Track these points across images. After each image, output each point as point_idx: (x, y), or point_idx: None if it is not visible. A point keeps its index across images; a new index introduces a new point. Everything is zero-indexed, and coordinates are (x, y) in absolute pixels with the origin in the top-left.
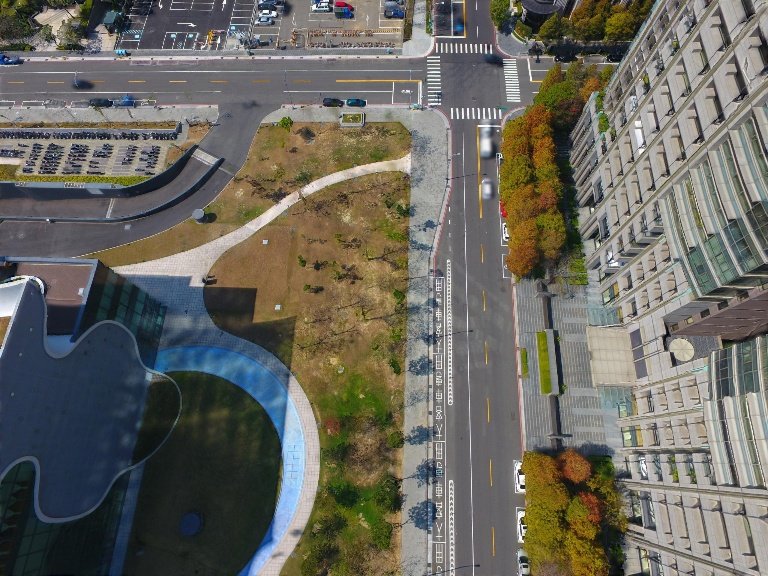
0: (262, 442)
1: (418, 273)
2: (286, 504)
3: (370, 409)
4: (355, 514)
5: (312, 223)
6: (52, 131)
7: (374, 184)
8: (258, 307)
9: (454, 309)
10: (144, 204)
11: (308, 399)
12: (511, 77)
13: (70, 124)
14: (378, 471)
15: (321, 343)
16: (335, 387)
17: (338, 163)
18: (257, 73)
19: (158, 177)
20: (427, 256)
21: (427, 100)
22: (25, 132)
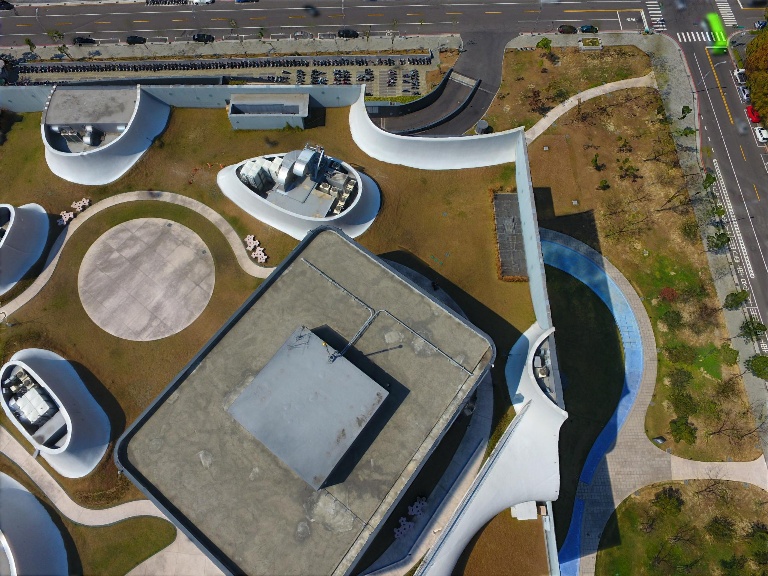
0: (596, 314)
1: (691, 171)
2: (633, 363)
3: (684, 283)
4: (697, 368)
5: (582, 132)
6: (310, 59)
7: (627, 98)
8: (556, 203)
9: (732, 200)
10: (415, 121)
11: (626, 277)
12: (723, 5)
13: (325, 53)
14: (706, 333)
15: (622, 231)
16: (646, 267)
17: (588, 81)
18: (488, 6)
19: (430, 95)
20: (695, 157)
21: (653, 26)
22: (286, 60)
